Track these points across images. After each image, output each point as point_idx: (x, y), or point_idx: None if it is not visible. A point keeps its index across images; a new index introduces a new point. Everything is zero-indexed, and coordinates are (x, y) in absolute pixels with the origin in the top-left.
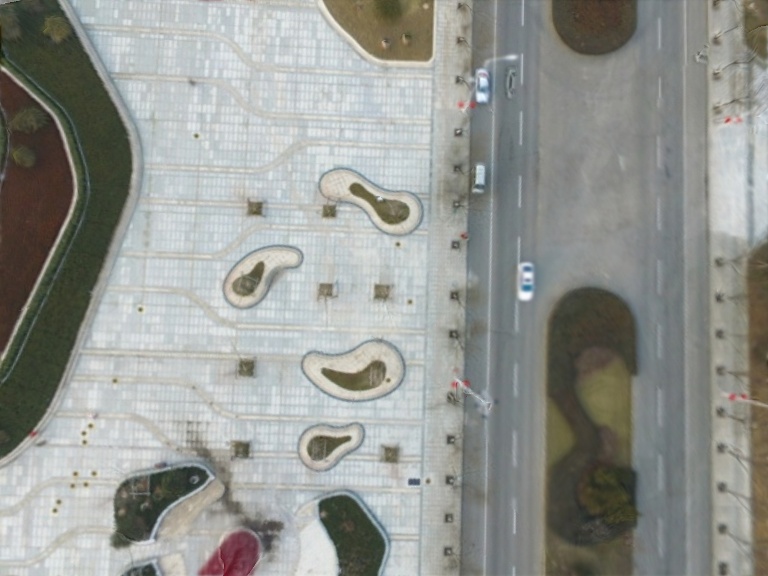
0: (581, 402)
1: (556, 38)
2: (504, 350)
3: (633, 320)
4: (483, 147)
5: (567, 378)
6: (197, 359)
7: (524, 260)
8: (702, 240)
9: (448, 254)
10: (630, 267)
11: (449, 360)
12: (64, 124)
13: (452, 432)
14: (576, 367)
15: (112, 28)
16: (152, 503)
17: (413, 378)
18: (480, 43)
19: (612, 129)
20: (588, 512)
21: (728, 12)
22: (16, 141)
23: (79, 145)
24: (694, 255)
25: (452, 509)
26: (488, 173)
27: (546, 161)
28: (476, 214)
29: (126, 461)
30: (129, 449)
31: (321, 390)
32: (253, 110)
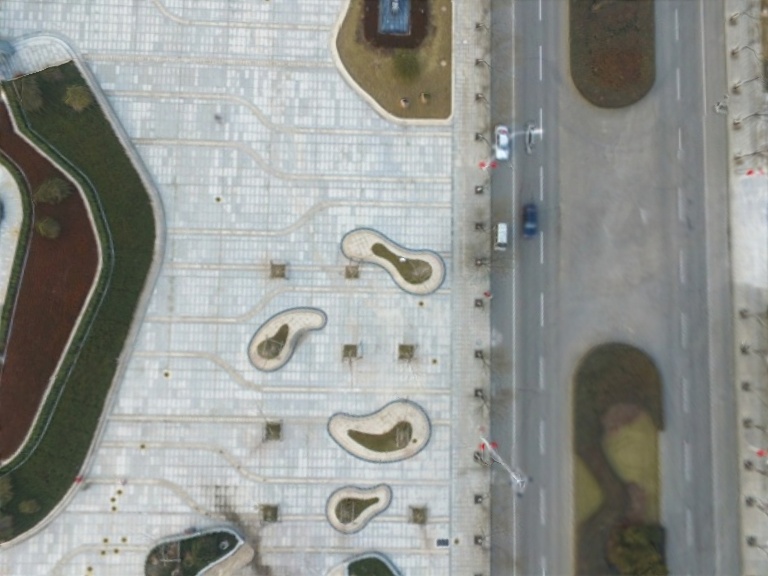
0: (608, 459)
1: (575, 92)
2: (529, 408)
3: (658, 375)
4: (504, 204)
5: (593, 435)
6: (224, 423)
7: (547, 316)
8: (726, 292)
9: (471, 312)
10: (654, 321)
11: (475, 419)
12: (88, 193)
13: (479, 492)
14: (602, 424)
15: (132, 94)
16: (183, 569)
17: (439, 438)
18: (499, 99)
19: (633, 182)
20: (618, 571)
21: (747, 62)
22: (41, 213)
23: (103, 213)
24: (718, 307)
25: (481, 569)
26: (509, 230)
27: (567, 216)
28: (498, 271)
29: (156, 527)
30: (158, 515)
31: (348, 452)
32: (274, 172)
